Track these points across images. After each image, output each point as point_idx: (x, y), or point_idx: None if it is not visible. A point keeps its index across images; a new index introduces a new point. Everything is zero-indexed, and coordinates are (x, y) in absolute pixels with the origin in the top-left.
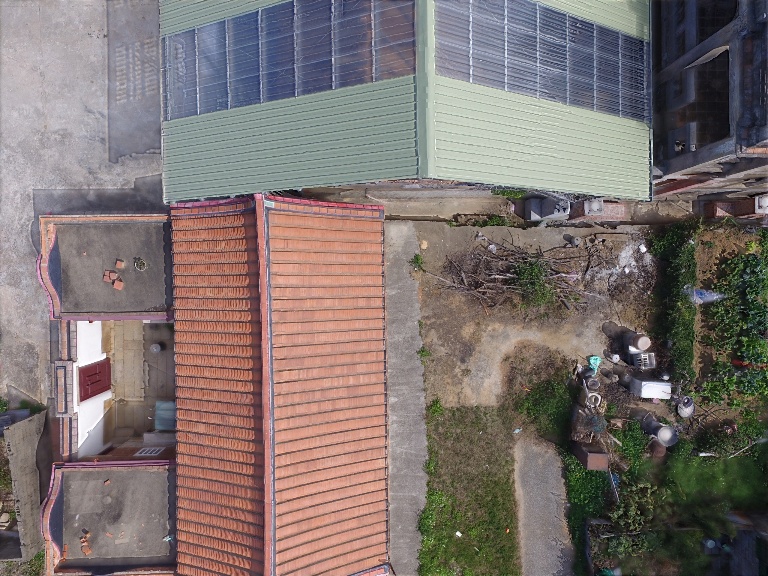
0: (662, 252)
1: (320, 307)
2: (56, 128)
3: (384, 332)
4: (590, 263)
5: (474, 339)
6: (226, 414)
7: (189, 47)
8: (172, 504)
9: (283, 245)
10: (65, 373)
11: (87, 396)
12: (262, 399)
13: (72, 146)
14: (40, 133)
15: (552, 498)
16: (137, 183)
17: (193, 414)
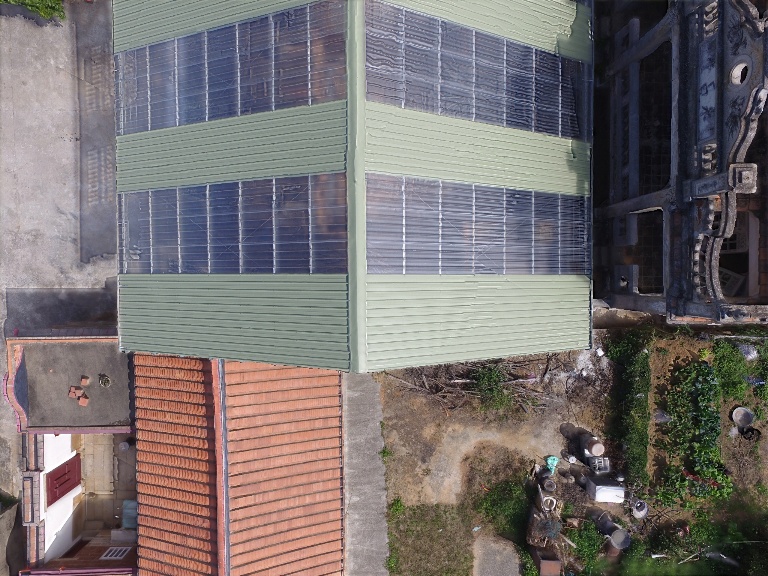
0: (618, 357)
1: (277, 432)
2: (29, 229)
3: (341, 450)
4: (548, 366)
5: (435, 440)
6: (184, 535)
7: (143, 207)
8: None
9: (239, 378)
10: (32, 484)
11: (55, 499)
12: (217, 529)
13: (45, 246)
14: (13, 233)
15: None
16: (108, 283)
17: (153, 532)
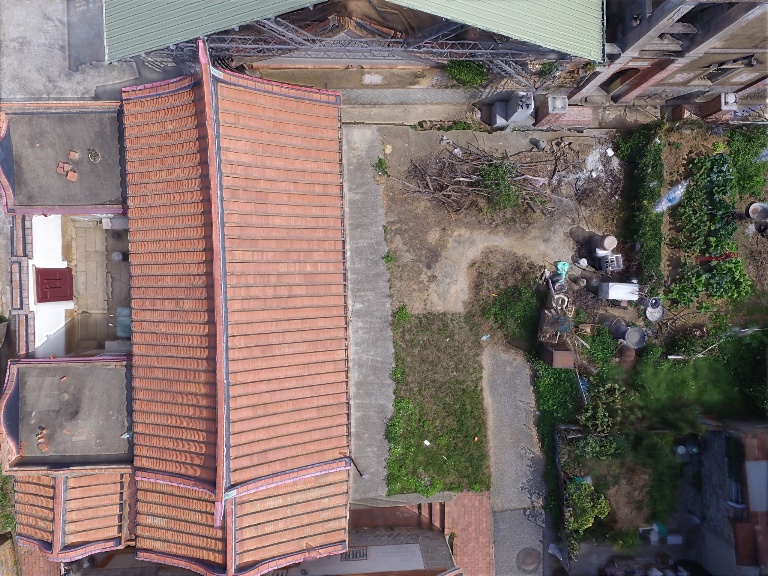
0: (629, 154)
1: (275, 190)
2: (15, 36)
3: (342, 221)
4: (557, 167)
5: (440, 244)
6: (180, 299)
7: None
8: (130, 401)
9: (234, 120)
10: (20, 269)
11: (45, 299)
12: (213, 275)
13: (31, 54)
14: None
15: (521, 406)
16: (98, 91)
17: (147, 302)
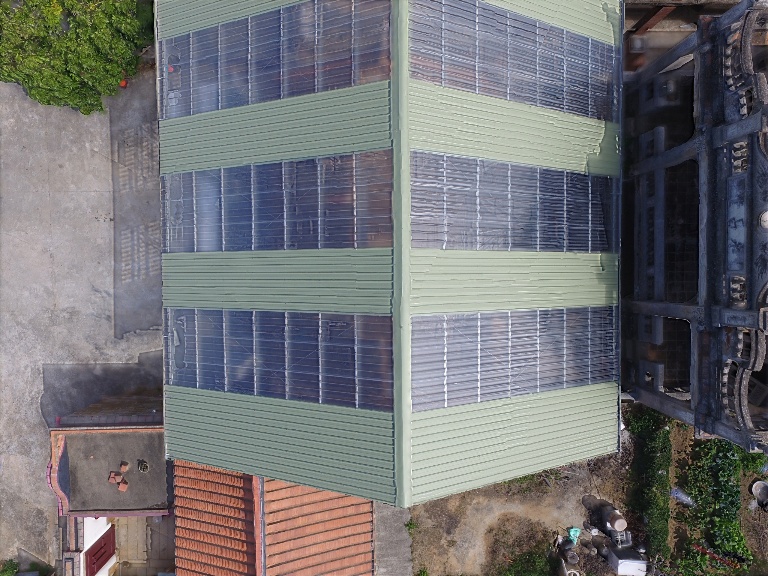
0: (639, 432)
1: (311, 521)
2: (65, 306)
3: (372, 535)
4: None
5: (460, 512)
6: None
7: (189, 324)
8: None
9: None
10: (73, 565)
11: (93, 574)
12: None
13: (80, 323)
14: (50, 311)
15: None
16: (141, 358)
17: None
